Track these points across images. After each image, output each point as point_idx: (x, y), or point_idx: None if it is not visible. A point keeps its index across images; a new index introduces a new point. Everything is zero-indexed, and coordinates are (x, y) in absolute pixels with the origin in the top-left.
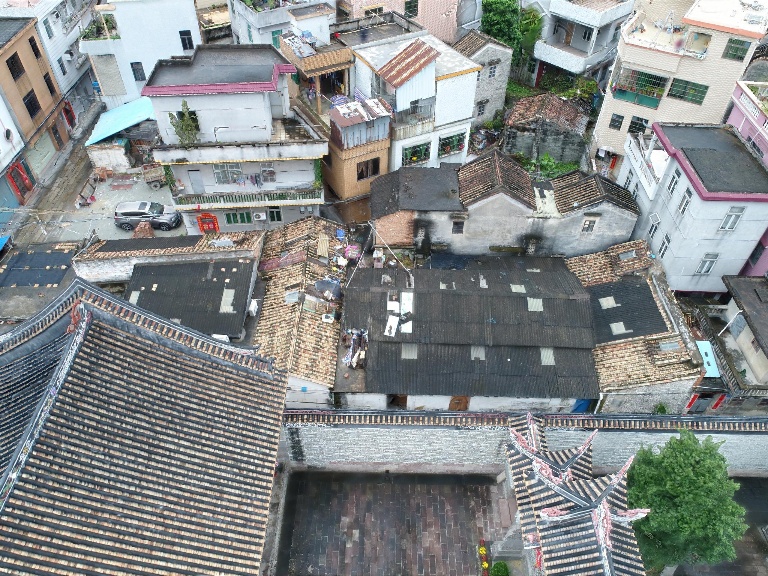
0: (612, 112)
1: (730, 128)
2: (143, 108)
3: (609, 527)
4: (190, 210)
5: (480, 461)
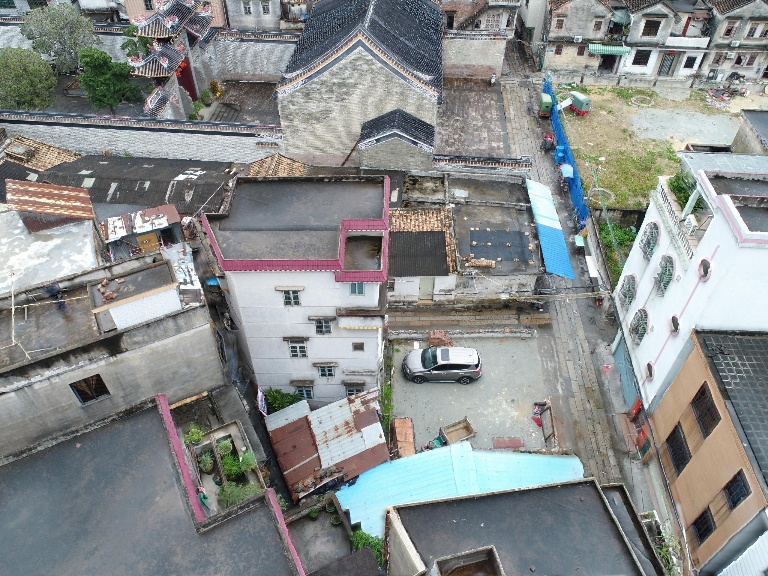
0: None
1: None
2: None
3: (159, 1)
4: None
5: None
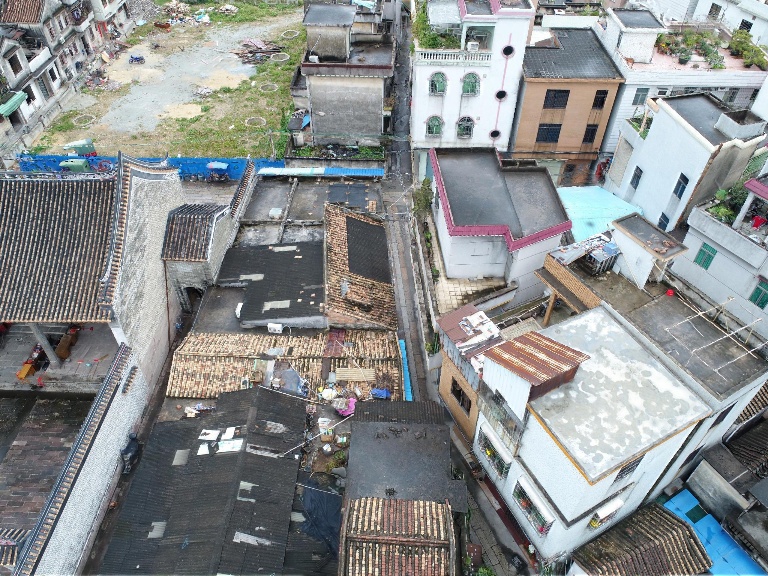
0: None
1: None
2: (593, 203)
3: None
4: None
5: None
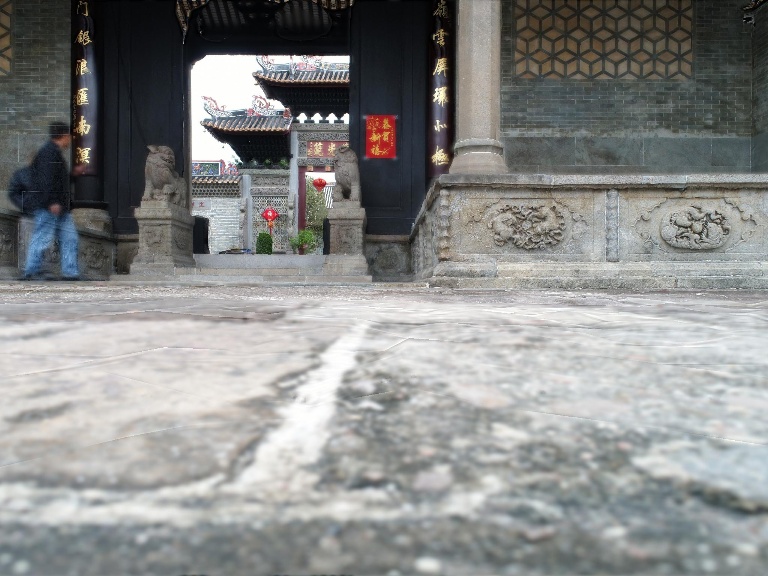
0: None
1: None
2: None
3: None
4: None
5: None
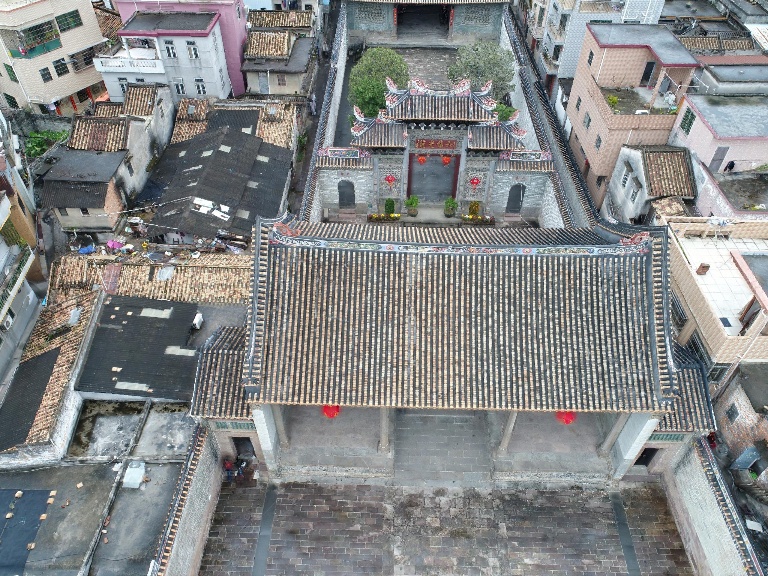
0: (38, 70)
1: (138, 13)
2: None
3: None
4: None
5: (319, 212)
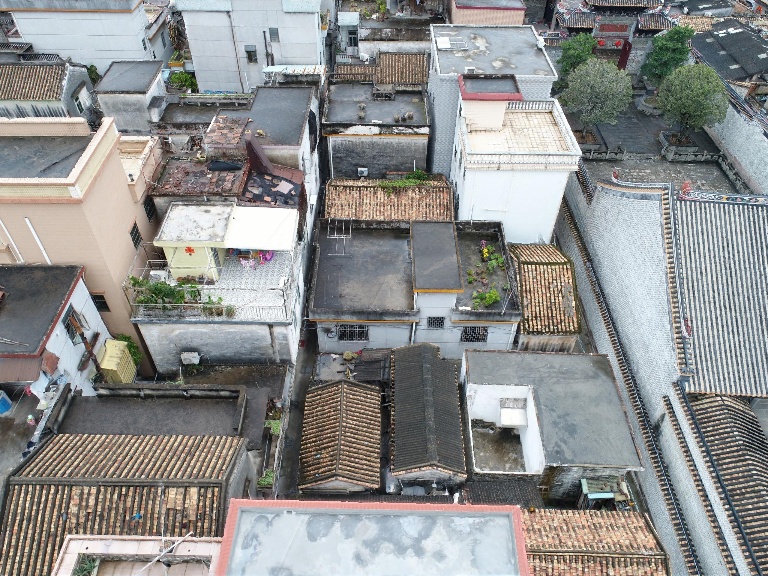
0: None
1: None
2: None
3: None
4: (757, 0)
5: None
